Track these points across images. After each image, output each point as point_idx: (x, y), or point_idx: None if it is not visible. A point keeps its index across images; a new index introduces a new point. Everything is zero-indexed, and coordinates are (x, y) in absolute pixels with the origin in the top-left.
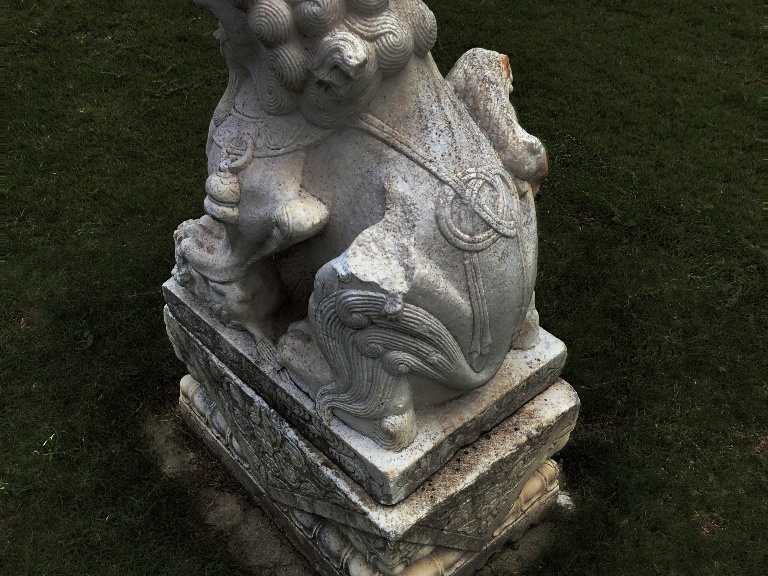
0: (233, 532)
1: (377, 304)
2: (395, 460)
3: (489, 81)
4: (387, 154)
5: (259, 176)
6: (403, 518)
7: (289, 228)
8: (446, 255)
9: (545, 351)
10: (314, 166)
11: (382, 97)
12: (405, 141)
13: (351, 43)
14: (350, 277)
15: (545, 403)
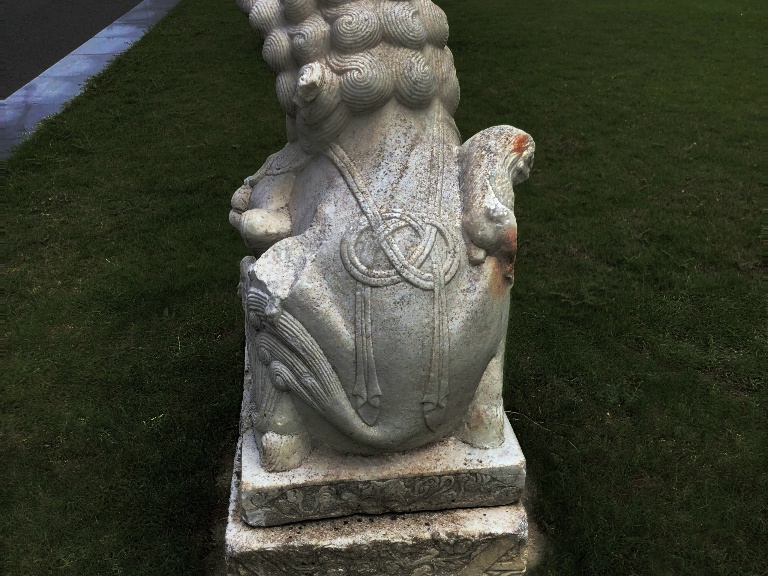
0: (222, 546)
1: (263, 304)
2: (260, 476)
3: (489, 150)
4: (336, 181)
5: (261, 189)
6: (249, 540)
7: (243, 228)
8: (340, 280)
9: (495, 457)
10: (298, 188)
11: (352, 132)
12: (353, 172)
13: (312, 70)
14: (253, 274)
15: (481, 517)
